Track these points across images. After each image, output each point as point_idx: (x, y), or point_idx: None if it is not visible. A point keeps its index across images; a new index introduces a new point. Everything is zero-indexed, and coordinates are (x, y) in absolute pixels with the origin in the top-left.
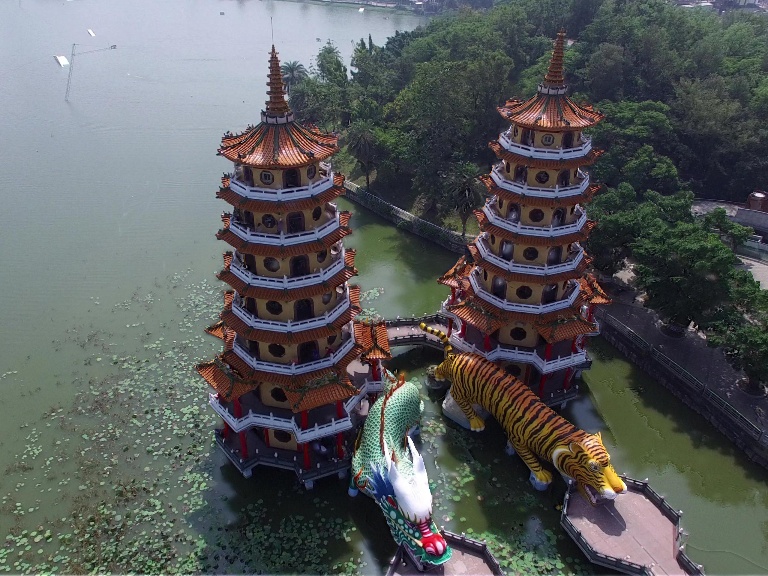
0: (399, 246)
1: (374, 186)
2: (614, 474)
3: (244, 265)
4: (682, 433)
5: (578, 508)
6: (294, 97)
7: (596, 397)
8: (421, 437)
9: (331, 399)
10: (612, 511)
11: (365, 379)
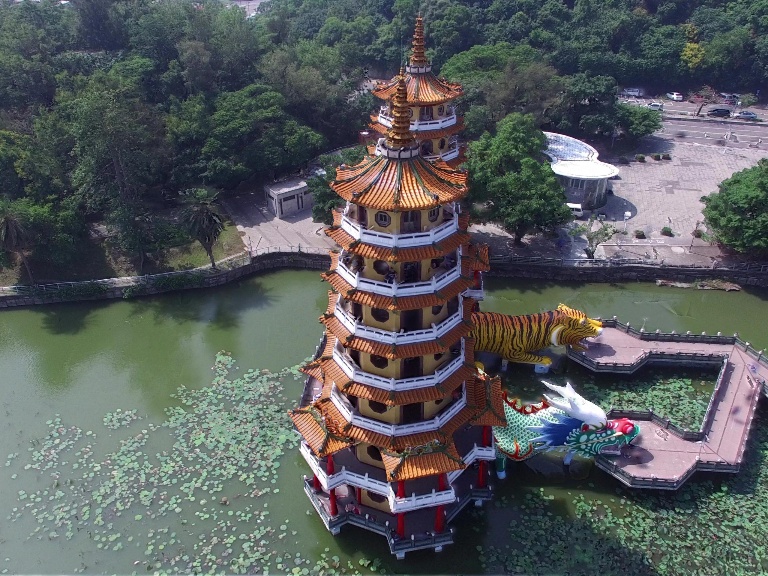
0: (158, 313)
1: None
2: None
3: (396, 332)
4: (526, 292)
5: None
6: None
7: None
8: None
9: None
10: (595, 345)
11: None
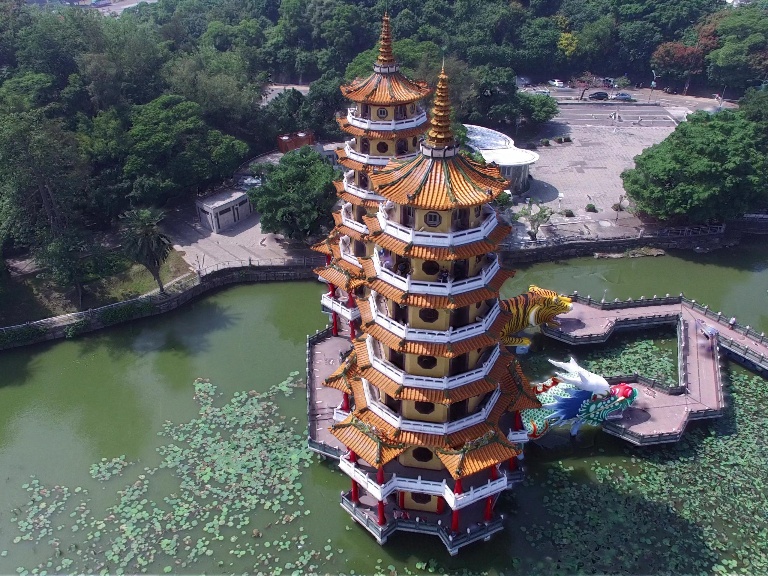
0: (112, 348)
1: None
2: None
3: (446, 330)
4: None
5: None
6: None
7: None
8: None
9: None
10: (565, 320)
11: None
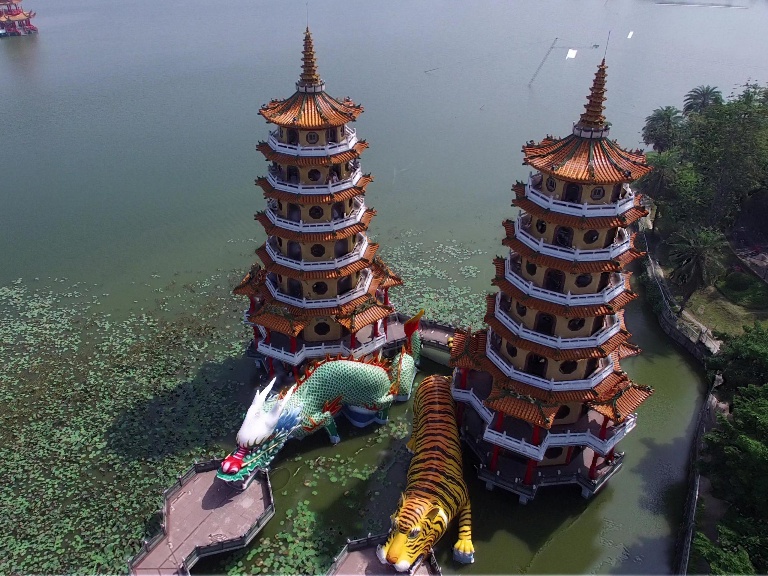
0: None
1: (667, 233)
2: (403, 545)
3: None
4: None
5: (375, 555)
6: (654, 119)
7: (574, 524)
8: (380, 427)
9: (275, 327)
10: None
11: (341, 341)
